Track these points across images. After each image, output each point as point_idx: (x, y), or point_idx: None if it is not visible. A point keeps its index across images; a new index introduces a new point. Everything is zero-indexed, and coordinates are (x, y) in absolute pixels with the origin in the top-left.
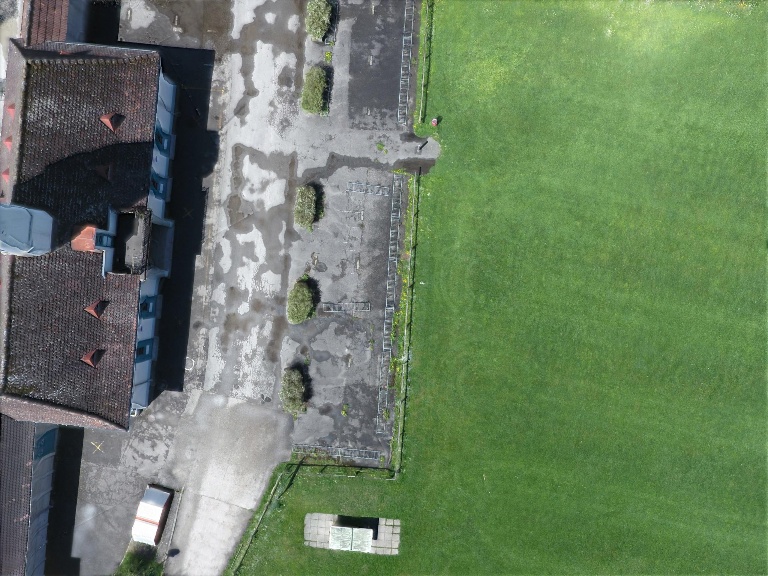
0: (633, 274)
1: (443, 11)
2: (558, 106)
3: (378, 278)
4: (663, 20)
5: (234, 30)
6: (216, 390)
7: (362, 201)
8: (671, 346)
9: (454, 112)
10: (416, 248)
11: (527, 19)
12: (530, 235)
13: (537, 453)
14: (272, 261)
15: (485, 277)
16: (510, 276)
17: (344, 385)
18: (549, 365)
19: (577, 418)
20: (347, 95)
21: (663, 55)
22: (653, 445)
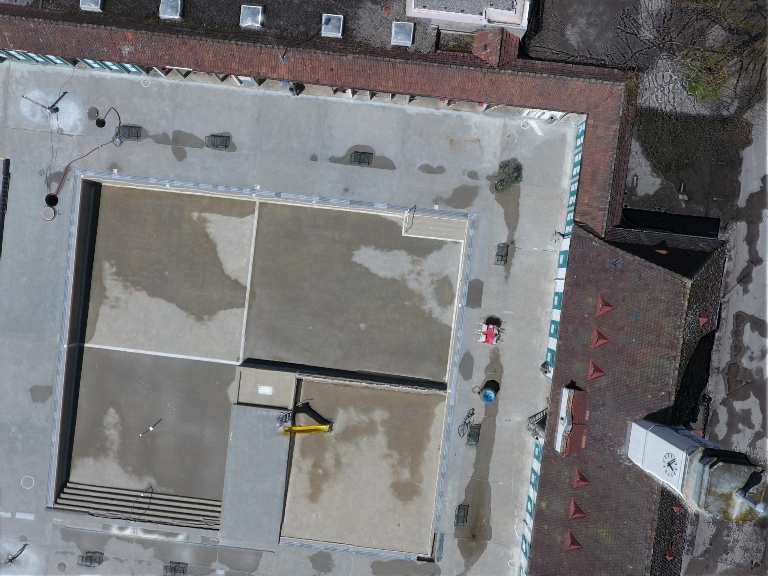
0: None
1: None
2: None
3: None
4: None
5: (740, 198)
6: (706, 555)
7: None
8: None
9: None
10: None
11: None
12: None
13: None
14: (767, 428)
15: None
16: None
17: None
18: None
19: None
20: None
21: None
22: None
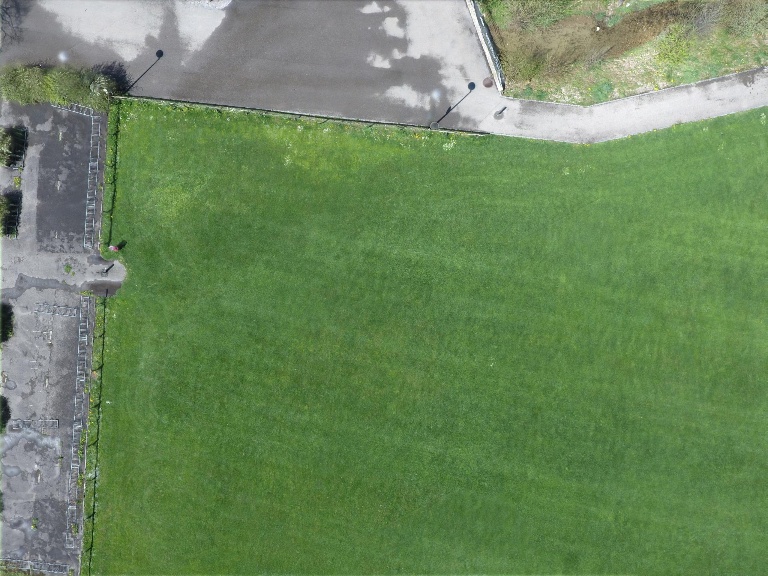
0: (313, 397)
1: (127, 139)
2: (238, 233)
3: (66, 396)
4: (339, 151)
5: None
6: None
7: (50, 321)
8: (350, 468)
9: (138, 237)
10: (102, 368)
11: (208, 147)
12: (212, 358)
13: (222, 570)
14: None
15: (168, 398)
16: (192, 397)
17: (34, 500)
18: (232, 484)
19: (260, 537)
20: (35, 219)
21: (339, 185)
22: (334, 565)
